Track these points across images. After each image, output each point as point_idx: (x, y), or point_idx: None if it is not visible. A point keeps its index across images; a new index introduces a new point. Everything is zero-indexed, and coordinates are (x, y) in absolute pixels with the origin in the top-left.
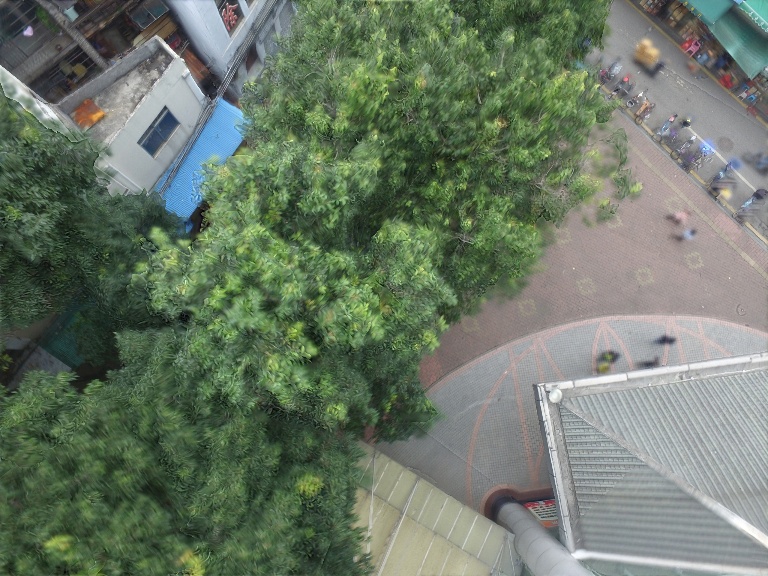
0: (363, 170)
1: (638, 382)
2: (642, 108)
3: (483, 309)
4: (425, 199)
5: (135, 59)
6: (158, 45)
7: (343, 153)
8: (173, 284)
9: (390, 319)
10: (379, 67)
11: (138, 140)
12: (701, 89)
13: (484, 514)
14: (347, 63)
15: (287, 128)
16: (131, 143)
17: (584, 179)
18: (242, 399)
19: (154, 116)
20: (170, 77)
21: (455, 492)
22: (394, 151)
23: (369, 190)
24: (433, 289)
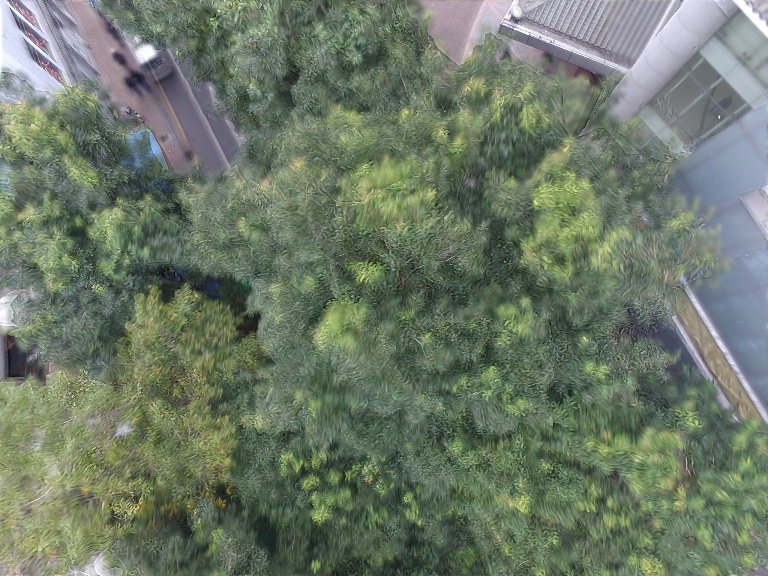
0: None
1: None
2: None
3: None
4: None
5: None
6: None
7: None
8: (259, 18)
9: None
10: None
11: None
12: None
13: None
14: None
15: None
16: None
17: None
18: (373, 24)
19: None
20: None
21: None
22: None
23: None
24: None
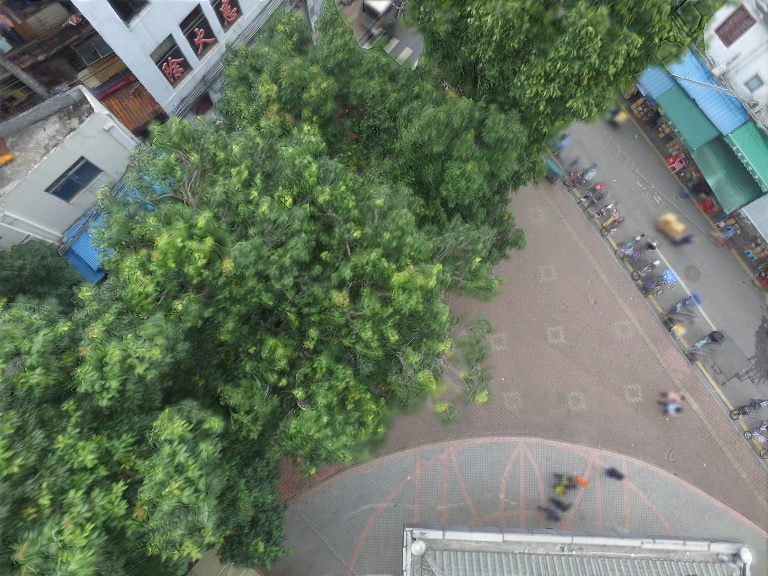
0: (140, 355)
1: (515, 545)
2: (610, 220)
3: (400, 405)
4: (261, 355)
5: (56, 105)
6: (83, 94)
7: (175, 294)
8: None
9: (143, 525)
10: (200, 228)
11: (46, 188)
12: (678, 209)
13: None
14: None
15: (133, 247)
16: (36, 191)
17: (423, 378)
18: None
19: (67, 166)
20: (88, 130)
21: None
22: (225, 306)
23: (154, 370)
24: (192, 504)
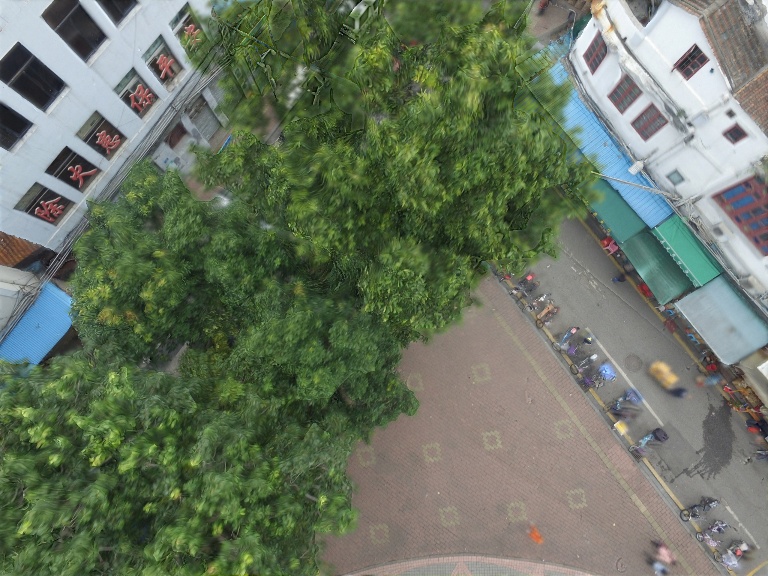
0: None
1: None
2: (543, 312)
3: None
4: None
5: None
6: None
7: None
8: None
9: None
10: None
11: None
12: (615, 294)
13: None
14: (8, 445)
15: None
16: None
17: None
18: None
19: None
20: None
21: None
22: None
23: None
24: None
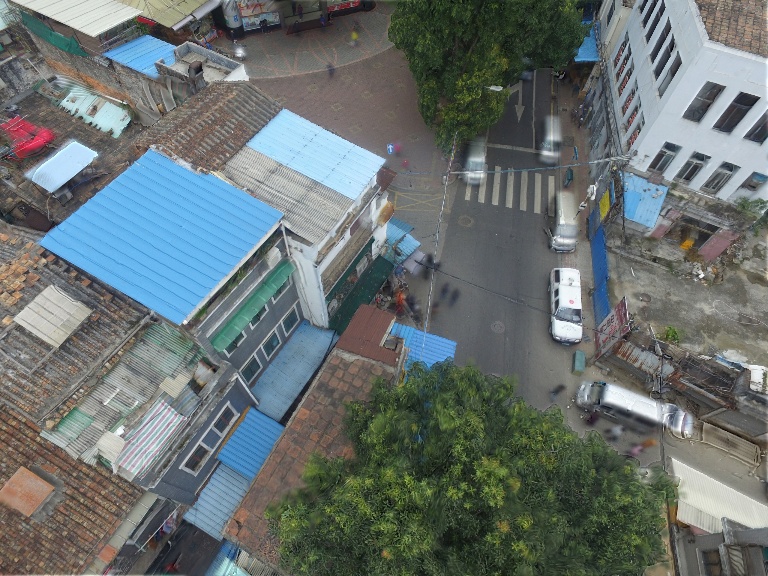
0: None
1: None
2: None
3: None
4: None
5: None
6: None
7: None
8: None
9: None
10: None
11: None
12: None
13: (376, 2)
14: None
15: None
16: None
17: None
18: None
19: None
20: None
21: (392, 4)
22: None
23: None
24: None
